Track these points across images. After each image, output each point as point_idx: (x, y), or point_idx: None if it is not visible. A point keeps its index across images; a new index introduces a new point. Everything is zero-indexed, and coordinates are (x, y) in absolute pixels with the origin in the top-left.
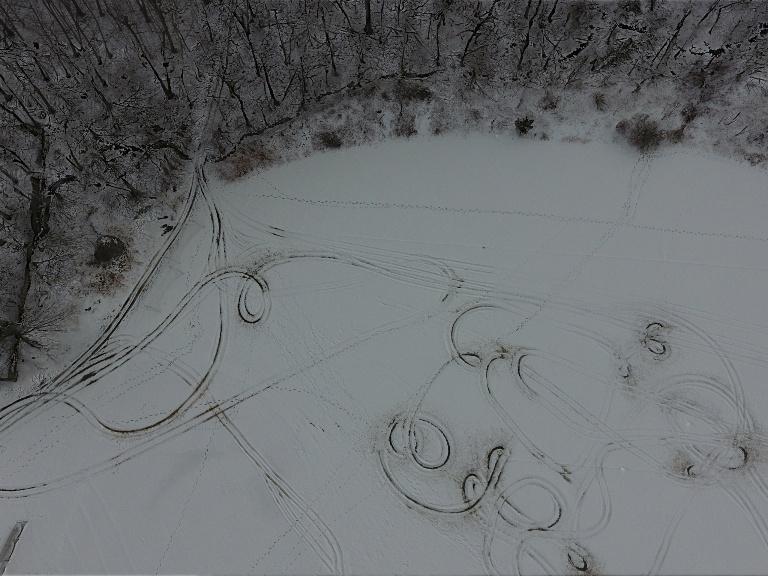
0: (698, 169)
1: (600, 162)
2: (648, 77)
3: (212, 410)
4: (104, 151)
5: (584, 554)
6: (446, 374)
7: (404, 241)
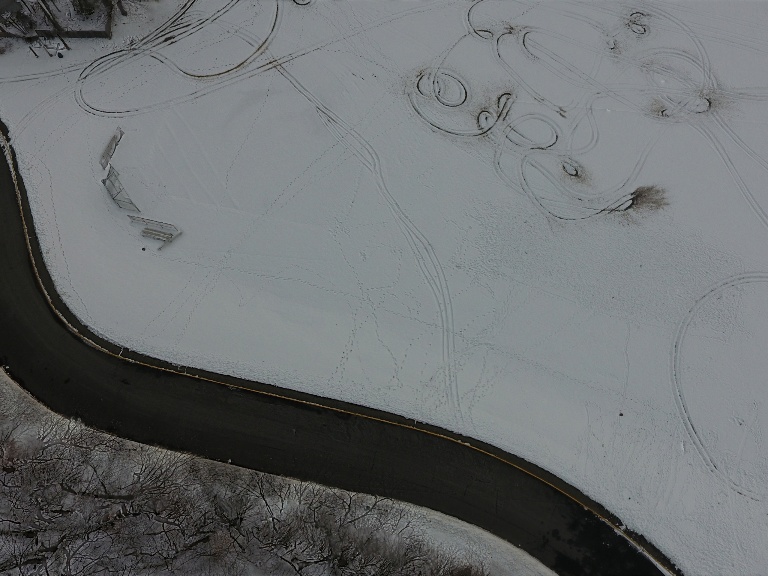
0: None
1: None
2: None
3: (272, 63)
4: None
5: (576, 165)
6: (464, 43)
7: None
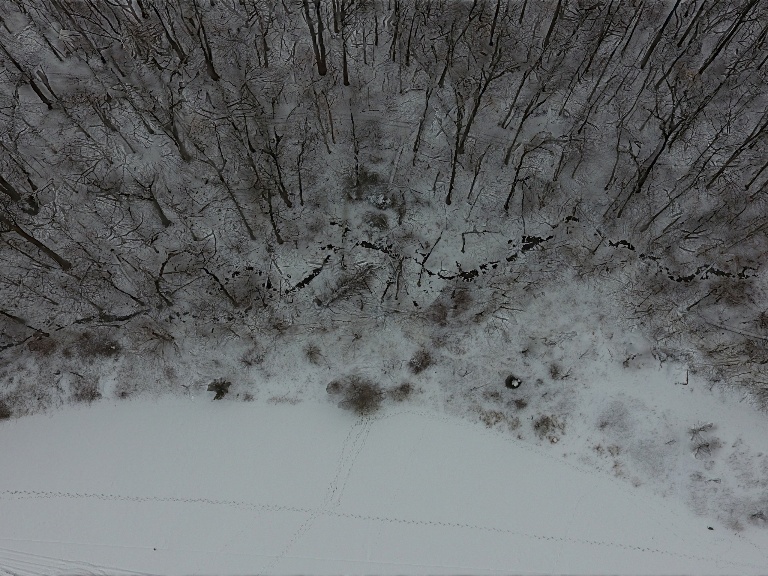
0: (424, 434)
1: (311, 427)
2: (380, 314)
3: None
4: None
5: None
6: None
7: (62, 543)
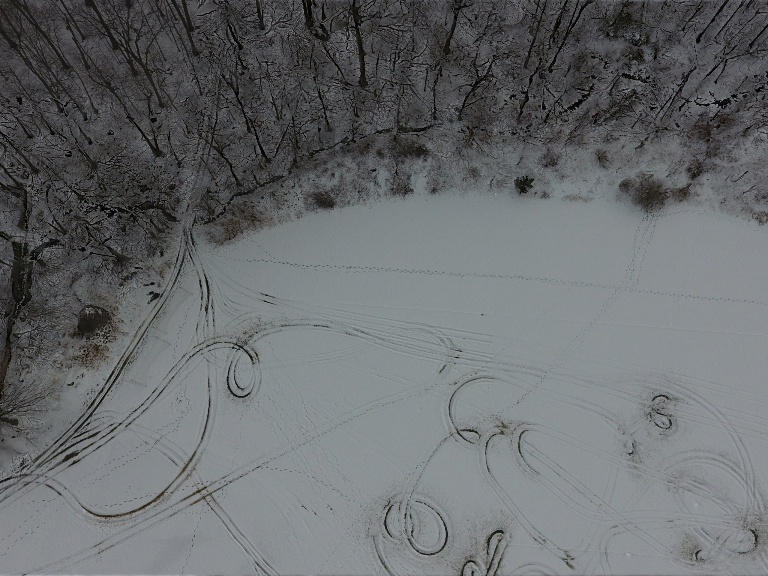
0: (704, 229)
1: (603, 222)
2: (652, 131)
3: (199, 492)
4: (89, 213)
5: None
6: (443, 452)
7: (400, 308)
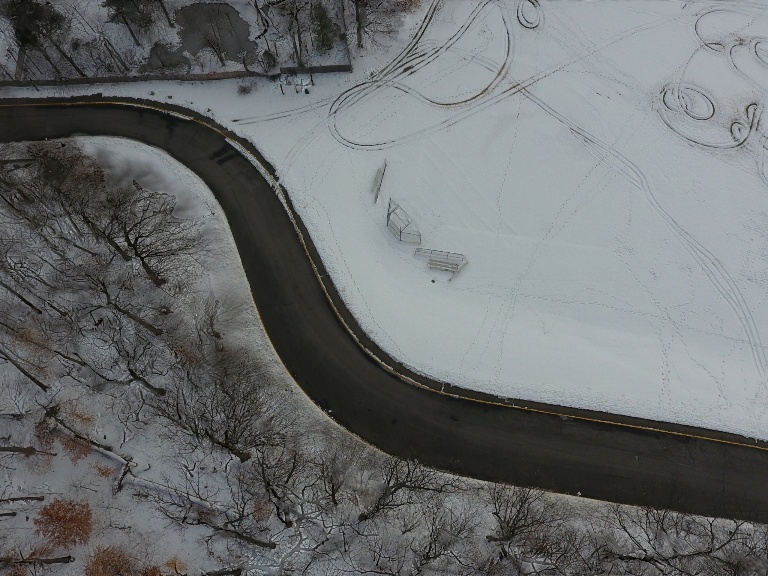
0: None
1: None
2: None
3: (515, 87)
4: None
5: None
6: (698, 57)
7: None
